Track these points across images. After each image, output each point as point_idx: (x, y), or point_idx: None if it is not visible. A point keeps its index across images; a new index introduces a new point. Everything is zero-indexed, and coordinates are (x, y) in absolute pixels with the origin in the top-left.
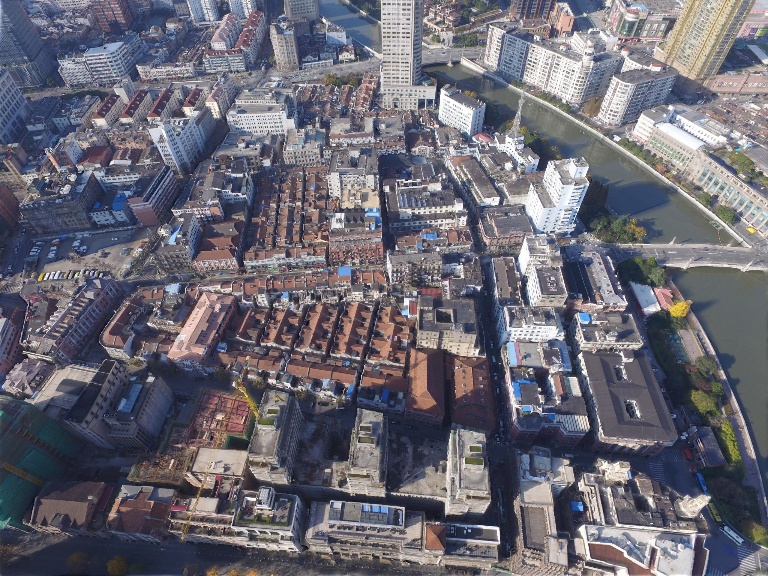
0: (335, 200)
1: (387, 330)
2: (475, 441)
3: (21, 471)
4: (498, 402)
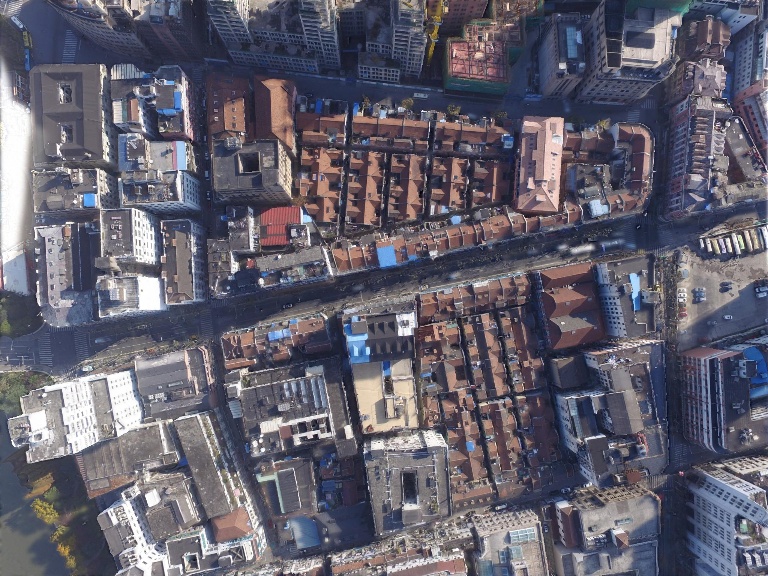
0: (429, 417)
1: (326, 190)
2: None
3: None
4: (206, 127)
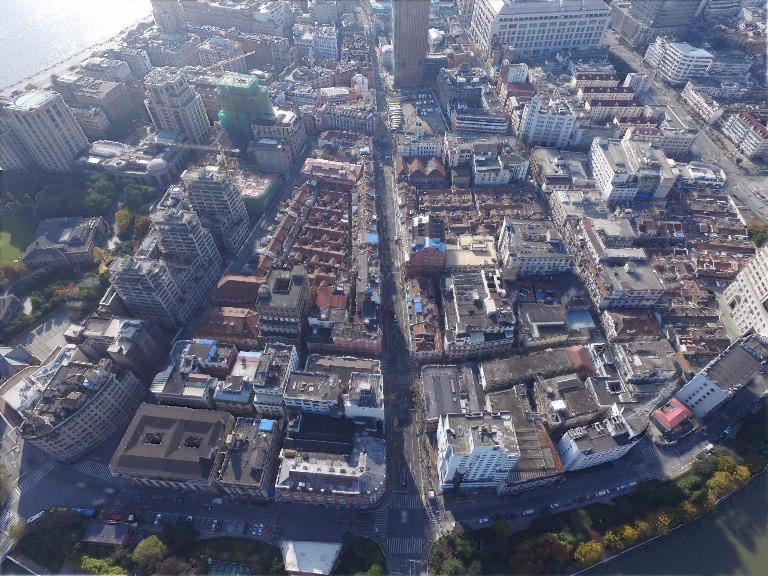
0: None
1: (312, 275)
2: (143, 268)
3: (235, 115)
4: None
